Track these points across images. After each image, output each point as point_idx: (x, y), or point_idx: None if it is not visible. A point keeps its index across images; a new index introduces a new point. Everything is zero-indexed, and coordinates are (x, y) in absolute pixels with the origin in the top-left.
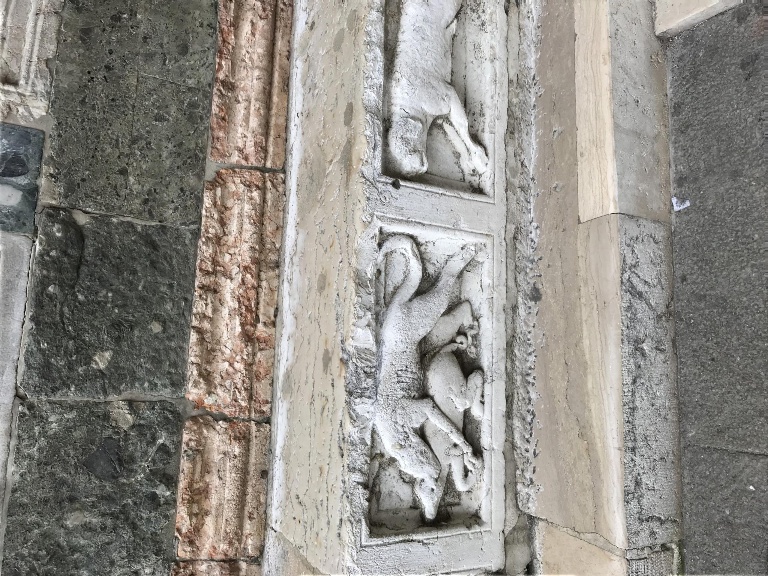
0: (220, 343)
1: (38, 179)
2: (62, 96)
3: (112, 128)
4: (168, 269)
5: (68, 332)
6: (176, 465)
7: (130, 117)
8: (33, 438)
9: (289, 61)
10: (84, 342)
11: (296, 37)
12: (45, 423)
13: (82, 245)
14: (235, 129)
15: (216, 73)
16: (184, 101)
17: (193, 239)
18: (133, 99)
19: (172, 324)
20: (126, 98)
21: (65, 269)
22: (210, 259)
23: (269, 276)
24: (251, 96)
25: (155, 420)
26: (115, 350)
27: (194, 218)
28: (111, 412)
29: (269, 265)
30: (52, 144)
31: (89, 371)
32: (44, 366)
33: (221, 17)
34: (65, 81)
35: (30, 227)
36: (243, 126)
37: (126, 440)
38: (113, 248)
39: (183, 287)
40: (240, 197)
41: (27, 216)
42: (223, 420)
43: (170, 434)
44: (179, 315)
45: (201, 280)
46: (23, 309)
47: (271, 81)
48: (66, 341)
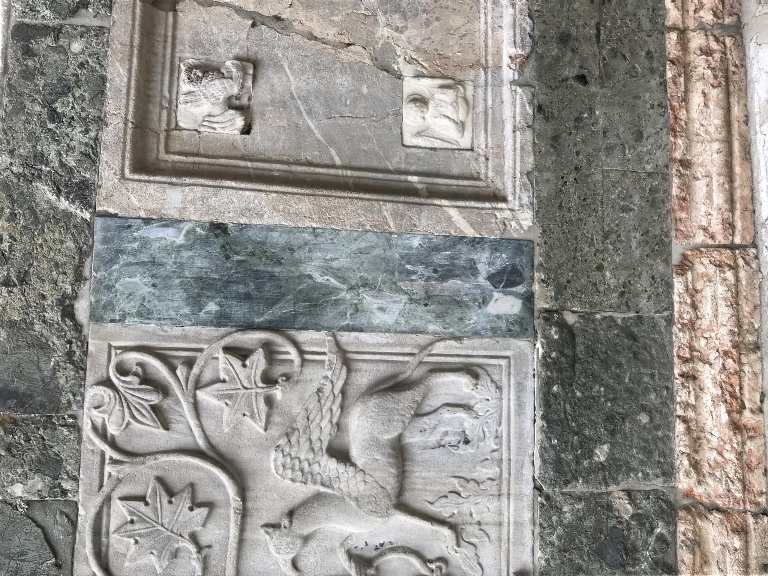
0: (704, 430)
1: (532, 286)
2: (543, 205)
3: (587, 227)
4: (649, 359)
5: (572, 428)
6: (673, 553)
7: (600, 213)
8: (552, 527)
9: (748, 126)
10: (585, 436)
11: (757, 101)
12: (560, 513)
13: (574, 344)
14: (697, 207)
15: (673, 153)
16: (646, 188)
17: (667, 326)
18: (601, 195)
19: (657, 413)
20: (595, 195)
21: (564, 369)
22: (687, 345)
23: (751, 359)
24: (712, 171)
25: (651, 509)
26: (612, 442)
27: (666, 304)
28: (613, 502)
29: (748, 346)
30: (540, 252)
31: (592, 464)
32: (556, 461)
33: (671, 94)
34: (544, 190)
35: (531, 332)
36: (707, 204)
37: (629, 529)
38: (600, 344)
39: (663, 375)
40: (711, 278)
41: (528, 322)
42: (716, 509)
43: (666, 523)
44: (662, 404)
45: (681, 367)
46: (533, 408)
47: (731, 151)
48: (572, 437)
